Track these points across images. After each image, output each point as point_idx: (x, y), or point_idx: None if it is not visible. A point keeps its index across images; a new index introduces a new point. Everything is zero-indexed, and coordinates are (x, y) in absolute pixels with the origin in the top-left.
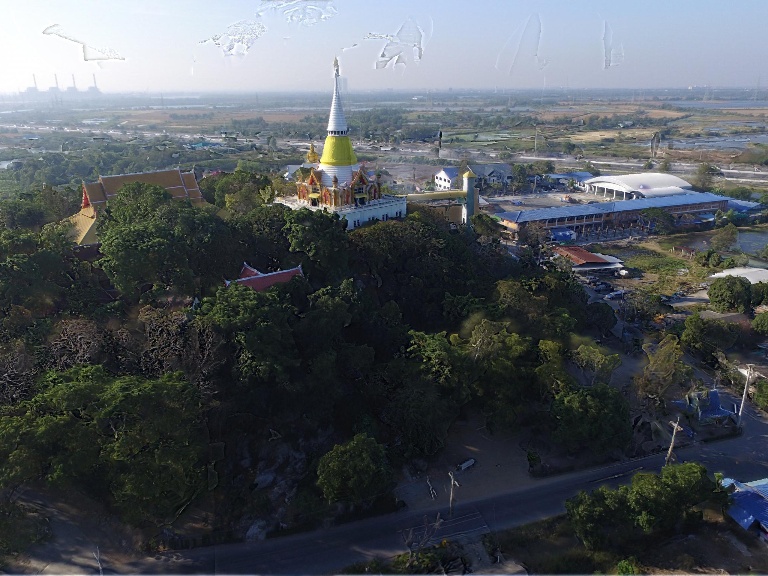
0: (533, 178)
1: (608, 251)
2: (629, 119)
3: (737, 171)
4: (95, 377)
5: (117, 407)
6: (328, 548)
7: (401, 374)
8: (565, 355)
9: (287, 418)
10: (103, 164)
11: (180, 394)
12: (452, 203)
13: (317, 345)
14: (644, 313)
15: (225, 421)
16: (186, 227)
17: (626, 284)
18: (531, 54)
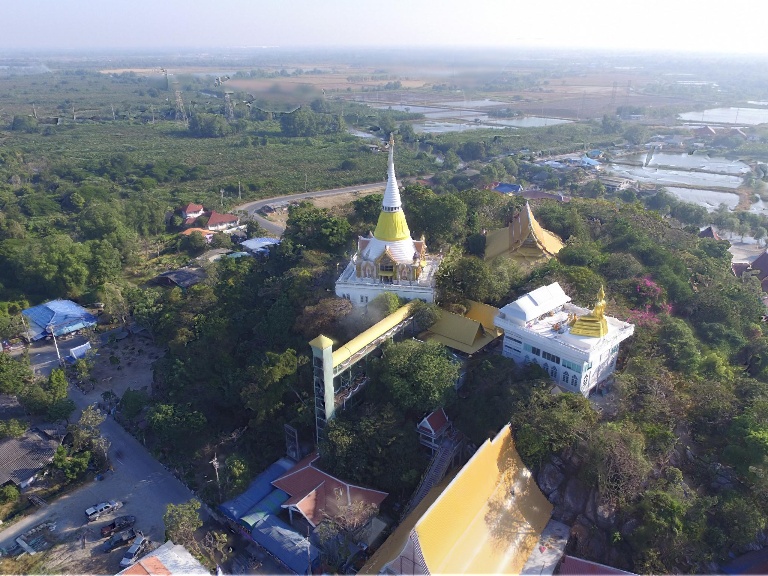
0: None
1: None
2: None
3: None
4: None
5: None
6: None
7: None
8: (168, 300)
9: None
10: None
11: None
12: None
13: None
14: None
15: None
16: None
17: None
18: None
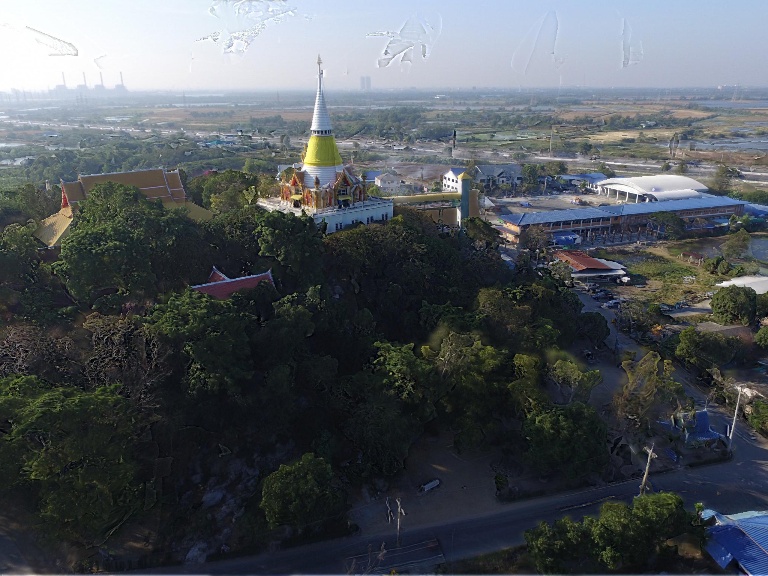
0: (544, 179)
1: (613, 256)
2: None
3: (759, 173)
4: (23, 389)
5: (32, 424)
6: (269, 575)
7: (365, 387)
8: (542, 370)
9: (244, 431)
10: (115, 161)
11: (111, 409)
12: (445, 205)
13: (276, 356)
14: (641, 324)
15: (177, 434)
16: (151, 229)
17: (627, 292)
18: (547, 52)
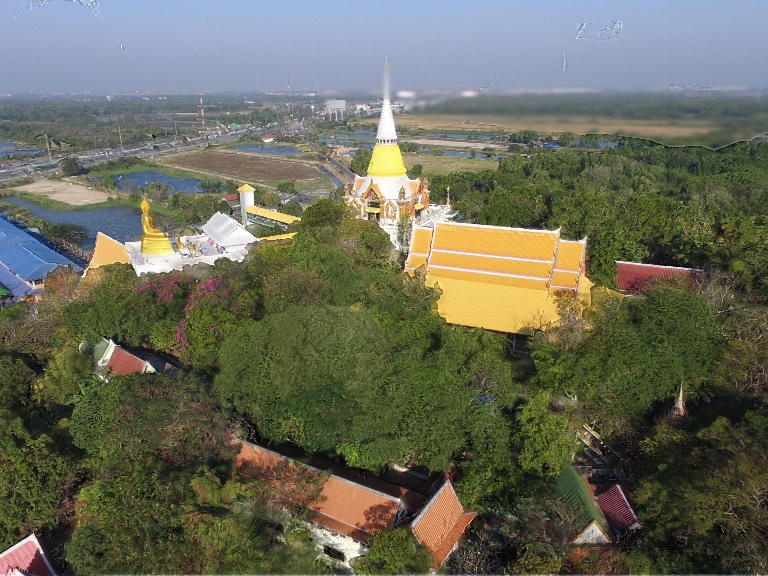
0: None
1: None
2: None
3: None
4: None
5: None
6: None
7: None
8: None
9: None
10: None
11: None
12: None
13: None
14: None
15: None
16: None
17: None
18: None
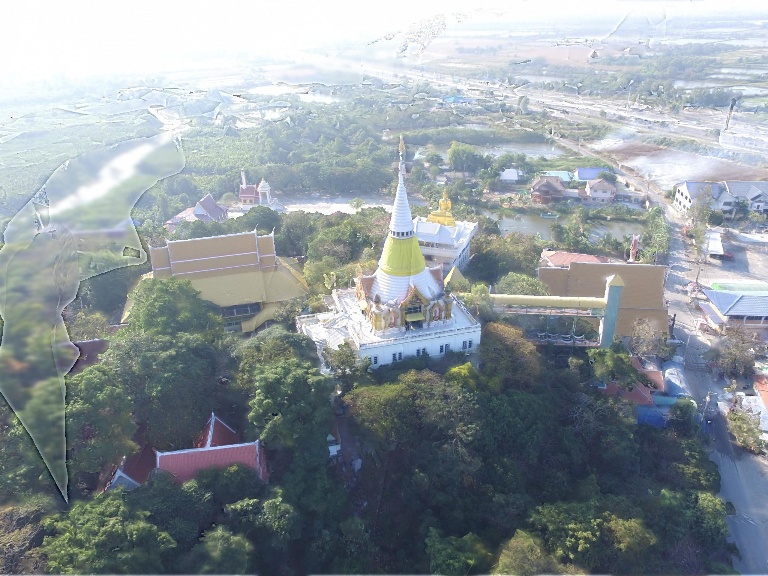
0: None
1: None
2: None
3: None
4: None
5: None
6: None
7: None
8: None
9: None
10: (340, 126)
11: None
12: (582, 314)
13: None
14: None
15: None
16: (145, 369)
17: None
18: None
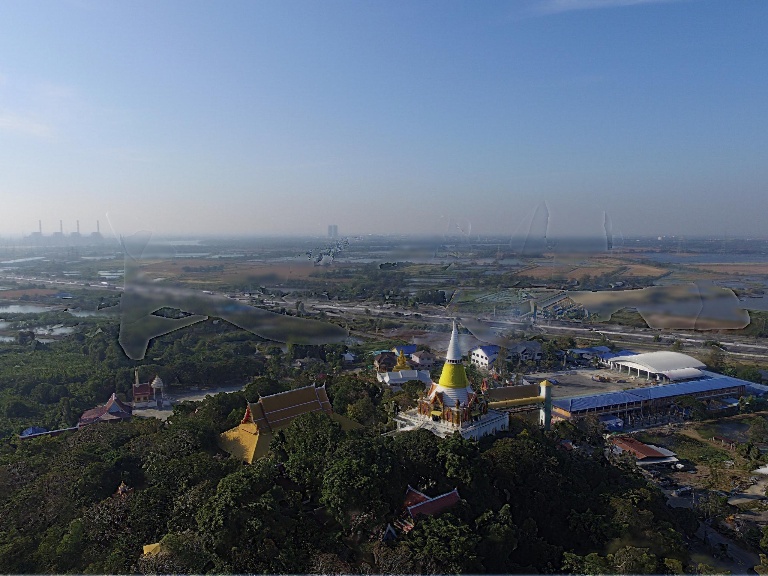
0: (559, 353)
1: (655, 439)
2: (618, 279)
3: None
4: None
5: None
6: None
7: None
8: (687, 572)
9: None
10: None
11: None
12: (533, 408)
13: (496, 568)
14: (717, 514)
15: None
16: (370, 459)
17: (685, 478)
18: (540, 236)
